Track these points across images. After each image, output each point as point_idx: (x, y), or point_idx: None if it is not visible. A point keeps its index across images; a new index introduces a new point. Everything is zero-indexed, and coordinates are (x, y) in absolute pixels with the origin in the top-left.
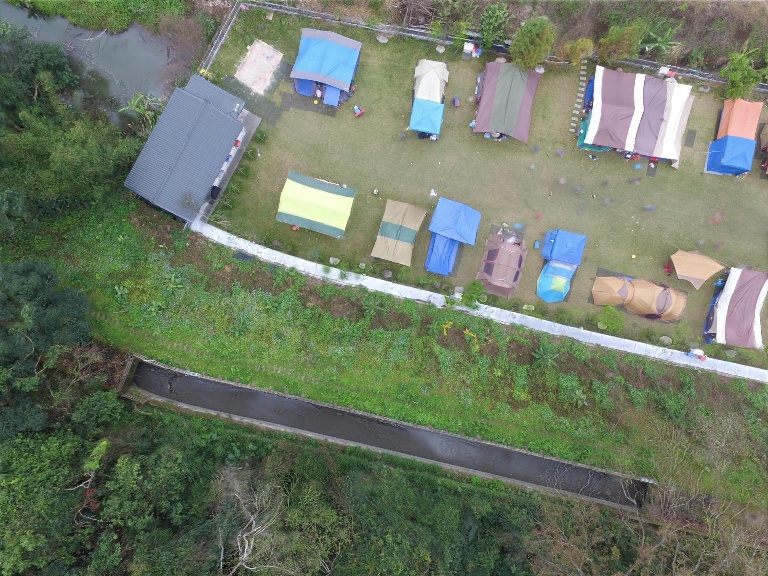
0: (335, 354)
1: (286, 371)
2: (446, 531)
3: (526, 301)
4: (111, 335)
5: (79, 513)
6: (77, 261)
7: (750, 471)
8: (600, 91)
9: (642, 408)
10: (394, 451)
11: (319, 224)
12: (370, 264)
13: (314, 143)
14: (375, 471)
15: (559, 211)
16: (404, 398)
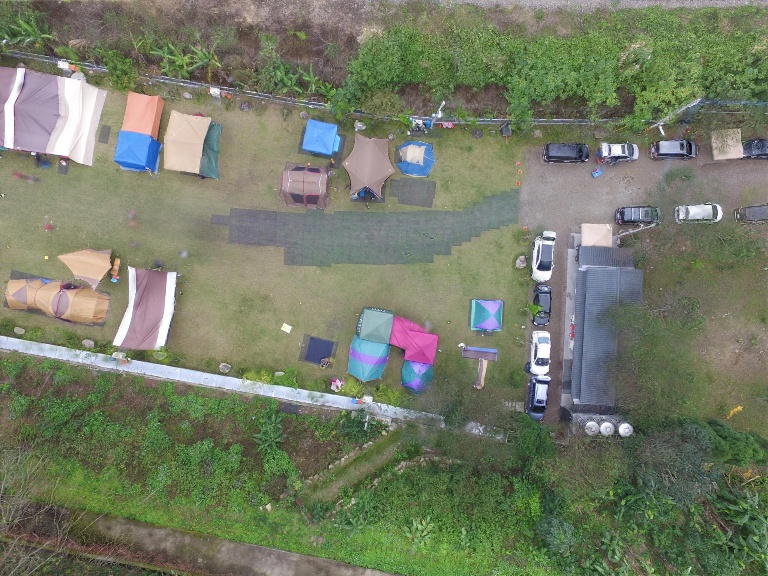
0: None
1: None
2: None
3: None
4: None
5: None
6: None
7: None
8: None
9: (19, 416)
10: None
11: None
12: None
13: None
14: None
15: None
16: None
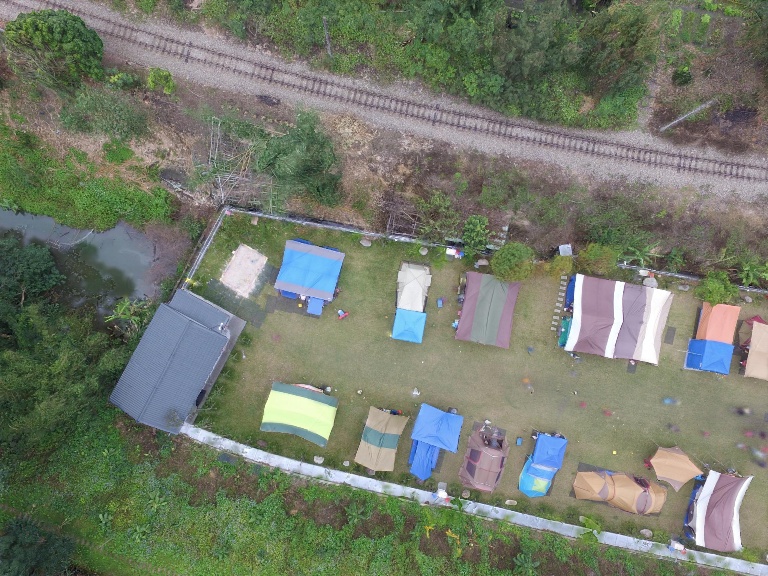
0: (318, 573)
1: None
2: None
3: (509, 495)
4: (95, 562)
5: None
6: (62, 484)
7: None
8: (580, 300)
9: None
10: None
11: (303, 430)
12: (354, 461)
13: (298, 344)
14: None
15: (541, 408)
16: None
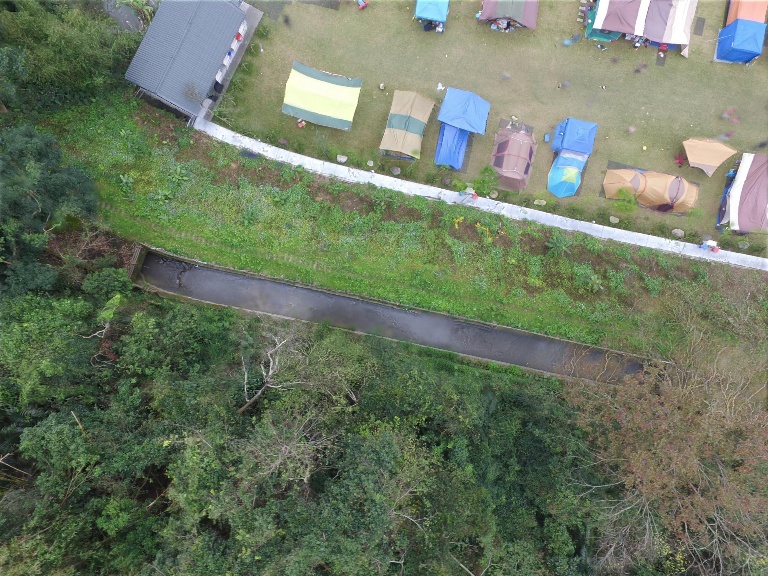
0: (347, 243)
1: (297, 259)
2: (468, 391)
3: (537, 196)
4: (117, 225)
5: (95, 358)
6: (79, 152)
7: (767, 350)
8: None
9: (657, 295)
10: None
11: (326, 117)
12: (378, 161)
13: (318, 37)
14: None
15: (568, 103)
16: (418, 284)
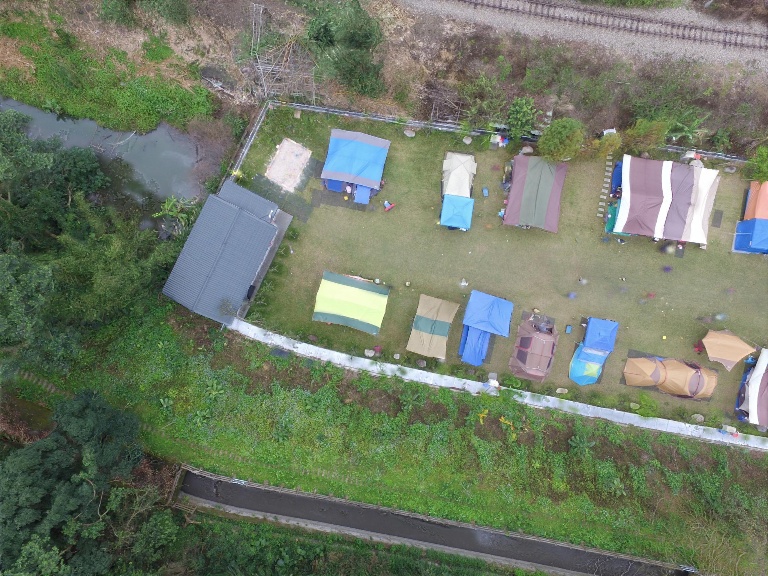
0: (377, 454)
1: (330, 474)
2: None
3: (559, 384)
4: (158, 446)
5: None
6: (121, 373)
7: None
8: (628, 180)
9: (678, 492)
10: (437, 544)
11: (354, 320)
12: (404, 354)
13: (345, 238)
14: (421, 570)
15: (589, 295)
16: (446, 496)
